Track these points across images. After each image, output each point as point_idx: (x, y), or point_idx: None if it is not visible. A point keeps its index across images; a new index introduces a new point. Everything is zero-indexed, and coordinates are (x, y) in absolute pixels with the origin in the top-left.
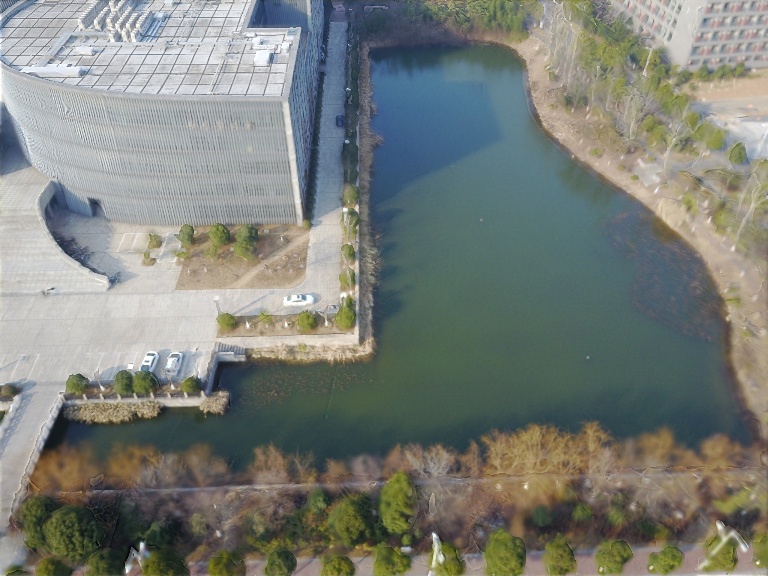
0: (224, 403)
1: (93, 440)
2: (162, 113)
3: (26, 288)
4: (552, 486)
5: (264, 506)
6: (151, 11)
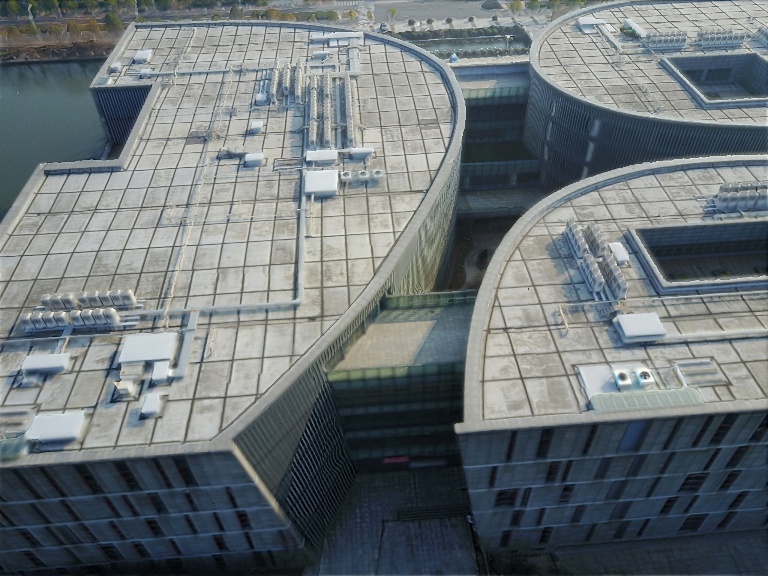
0: None
1: None
2: None
3: None
4: (82, 53)
5: None
6: (270, 95)
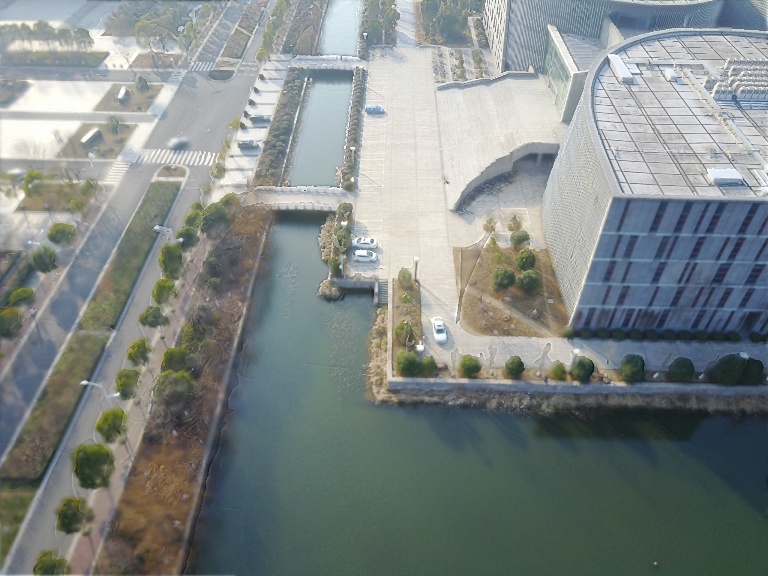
0: (324, 292)
1: (308, 234)
2: (583, 136)
3: (448, 171)
4: None
5: (220, 320)
6: None
